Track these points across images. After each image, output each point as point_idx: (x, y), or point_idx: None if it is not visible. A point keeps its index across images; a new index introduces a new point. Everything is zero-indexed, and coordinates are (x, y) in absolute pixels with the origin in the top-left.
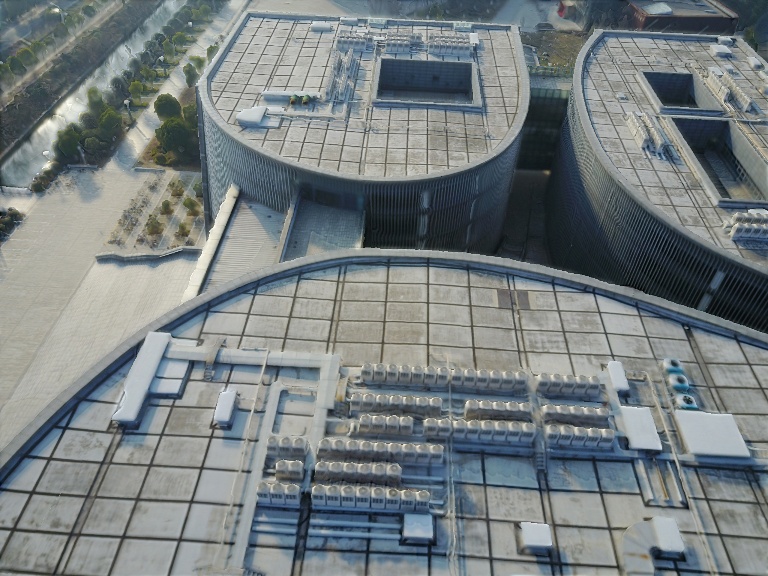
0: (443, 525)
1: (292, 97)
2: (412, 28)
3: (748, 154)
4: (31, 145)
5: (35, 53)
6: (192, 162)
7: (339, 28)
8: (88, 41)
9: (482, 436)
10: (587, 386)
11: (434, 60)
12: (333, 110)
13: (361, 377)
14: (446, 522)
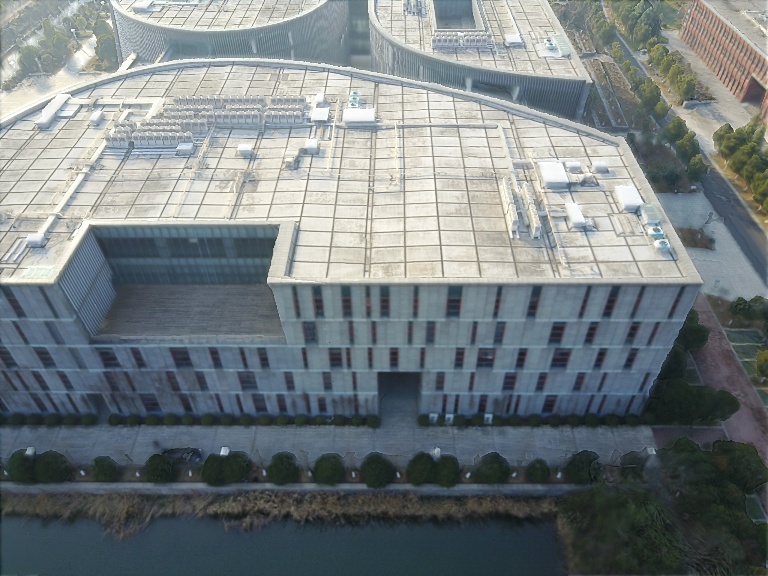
0: (200, 148)
1: None
2: None
3: (475, 10)
4: (3, 70)
5: (4, 6)
6: None
7: None
8: None
9: (232, 120)
10: (298, 100)
11: None
12: (200, 1)
13: (174, 104)
14: (201, 147)
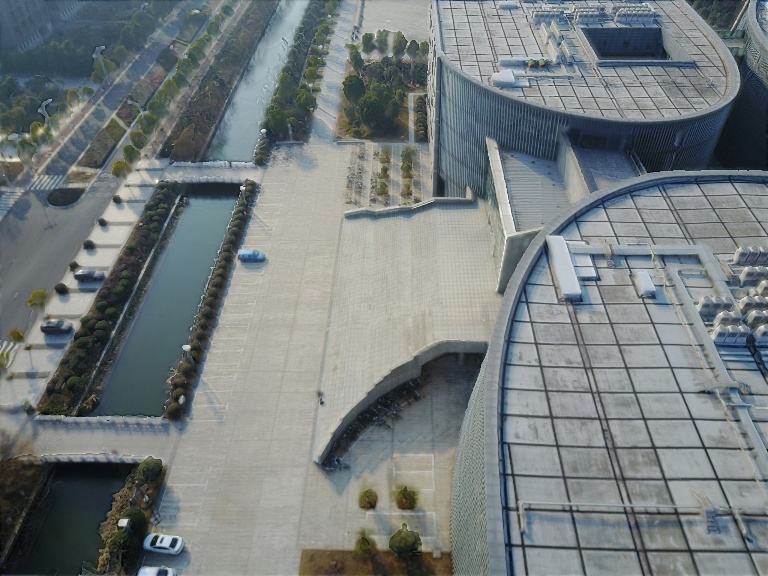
0: None
1: (530, 61)
2: (586, 2)
3: None
4: (219, 130)
5: None
6: (386, 134)
7: (522, 5)
8: (238, 37)
9: None
10: None
11: (627, 27)
12: None
13: (738, 258)
14: None
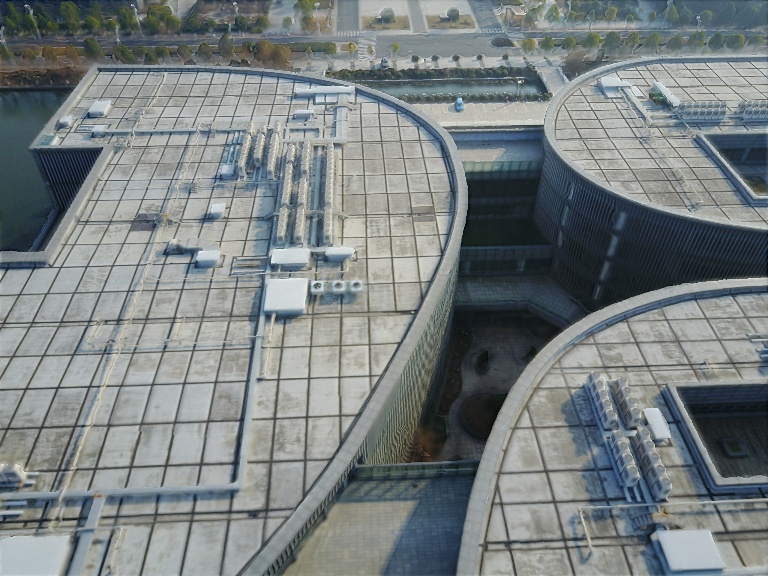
0: None
1: None
2: None
3: None
4: None
5: (749, 44)
6: None
7: None
8: None
9: None
10: None
11: None
12: (663, 118)
13: None
14: None
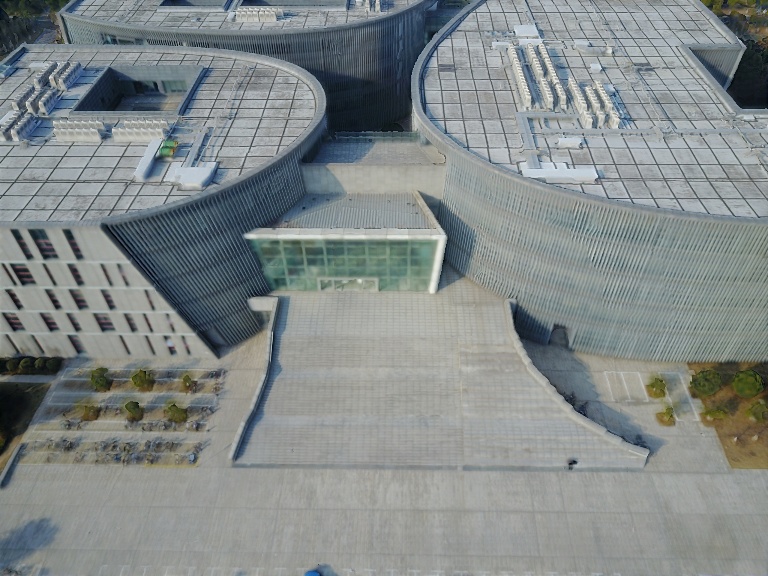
0: None
1: (164, 151)
2: None
3: None
4: None
5: None
6: (15, 410)
7: None
8: None
9: None
10: None
11: (93, 84)
12: None
13: None
14: None
